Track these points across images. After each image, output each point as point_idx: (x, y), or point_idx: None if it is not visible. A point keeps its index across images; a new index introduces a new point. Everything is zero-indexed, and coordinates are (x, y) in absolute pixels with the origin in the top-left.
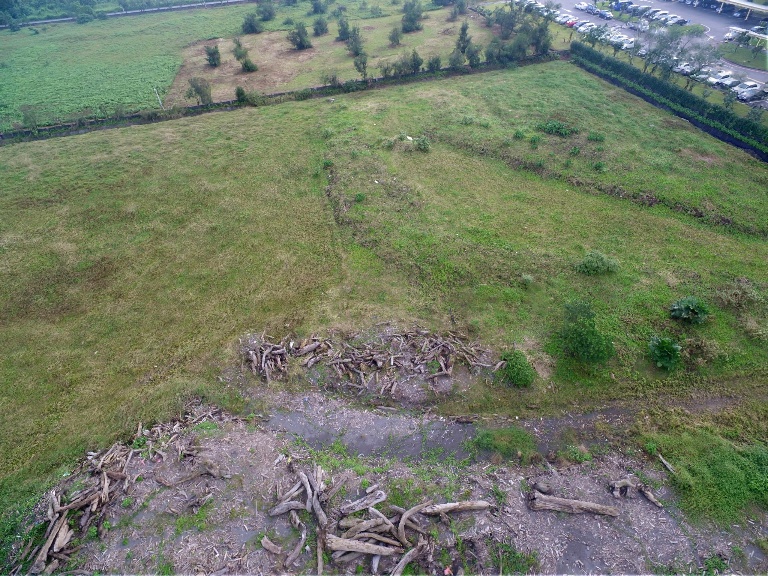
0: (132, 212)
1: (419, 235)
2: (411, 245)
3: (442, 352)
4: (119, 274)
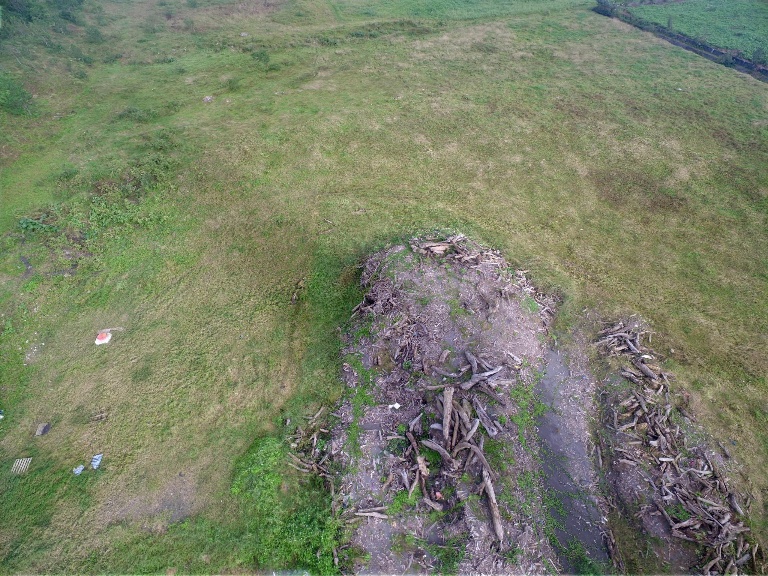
0: (762, 196)
1: None
2: None
3: (708, 525)
4: (671, 214)
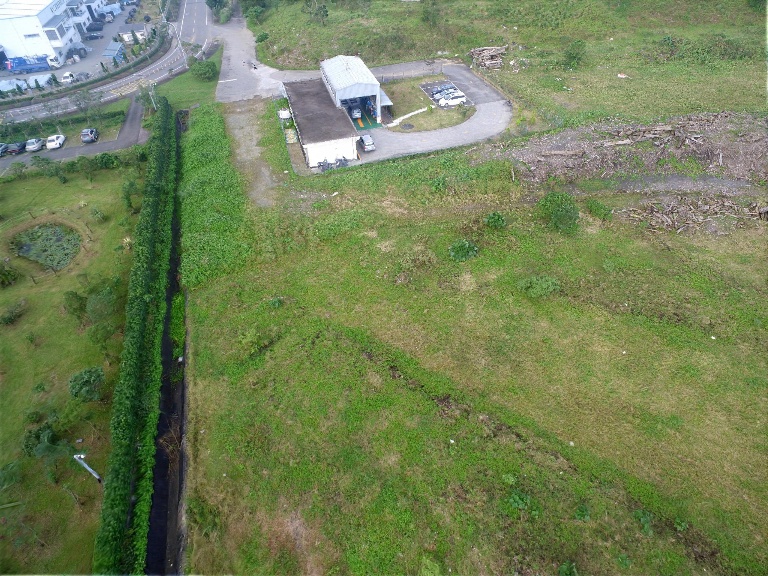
0: None
1: (764, 321)
2: (762, 310)
3: None
4: None
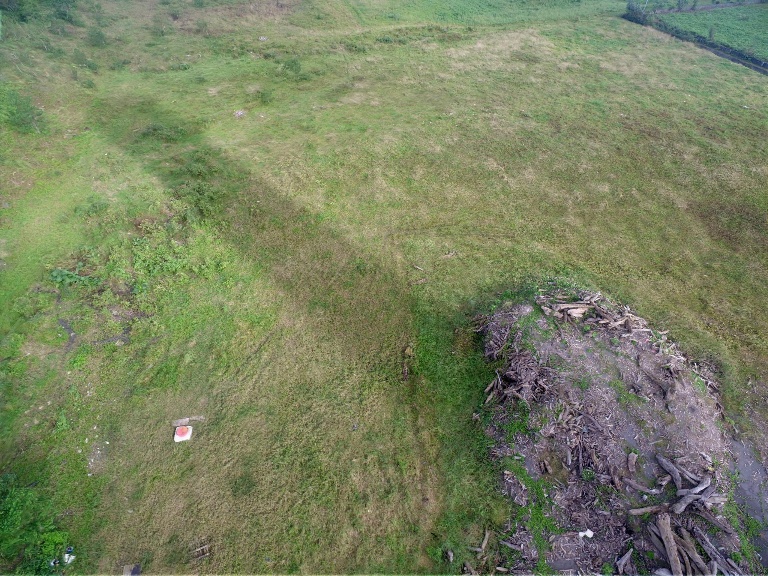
0: None
1: None
2: None
3: None
4: None
